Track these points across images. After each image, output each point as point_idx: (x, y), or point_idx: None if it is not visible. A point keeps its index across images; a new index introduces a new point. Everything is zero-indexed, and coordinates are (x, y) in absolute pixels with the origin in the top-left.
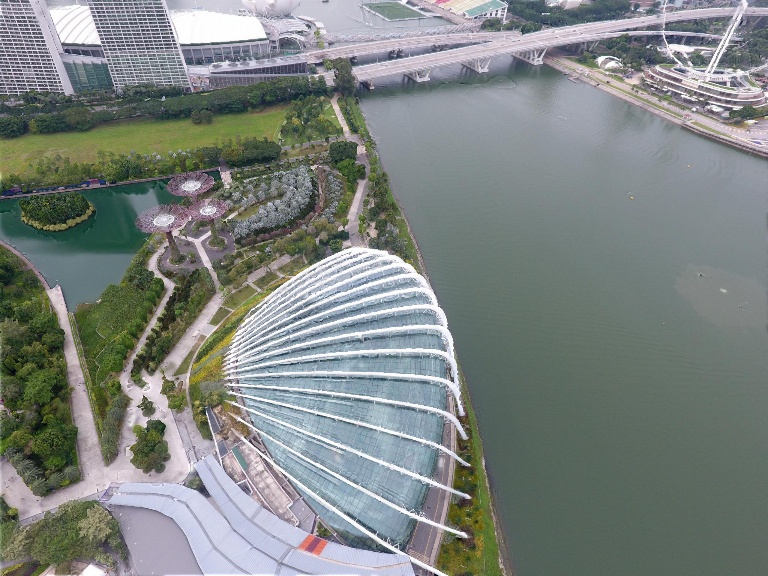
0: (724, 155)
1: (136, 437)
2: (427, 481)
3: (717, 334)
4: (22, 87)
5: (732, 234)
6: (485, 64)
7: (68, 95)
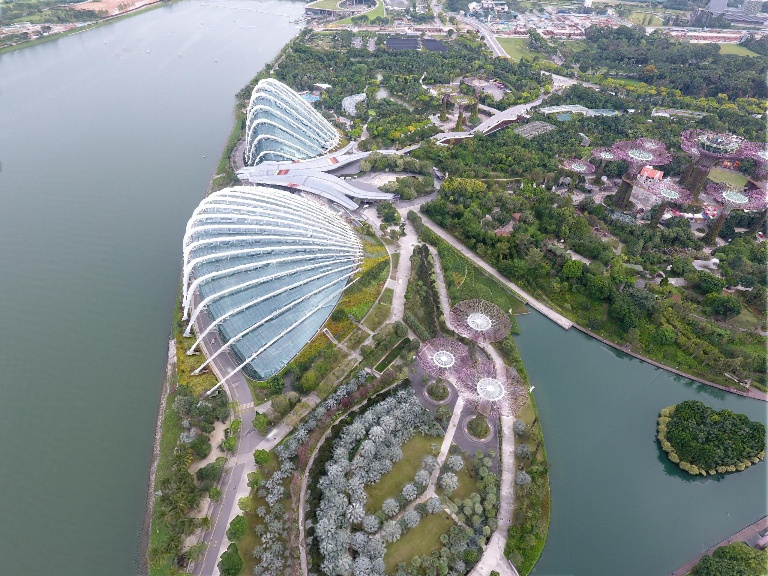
0: None
1: None
2: None
3: None
4: None
5: None
6: None
7: None
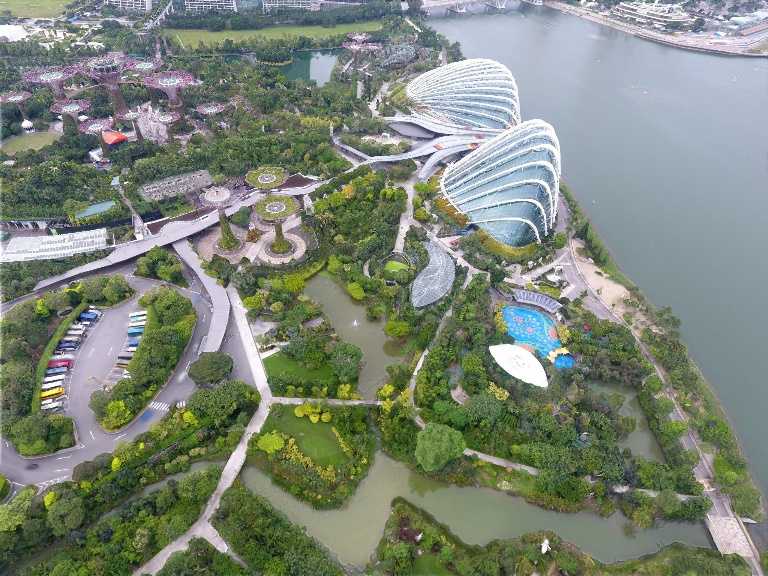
0: (660, 51)
1: None
2: (510, 111)
3: (639, 104)
4: (206, 6)
5: (655, 76)
6: (503, 3)
7: (237, 11)
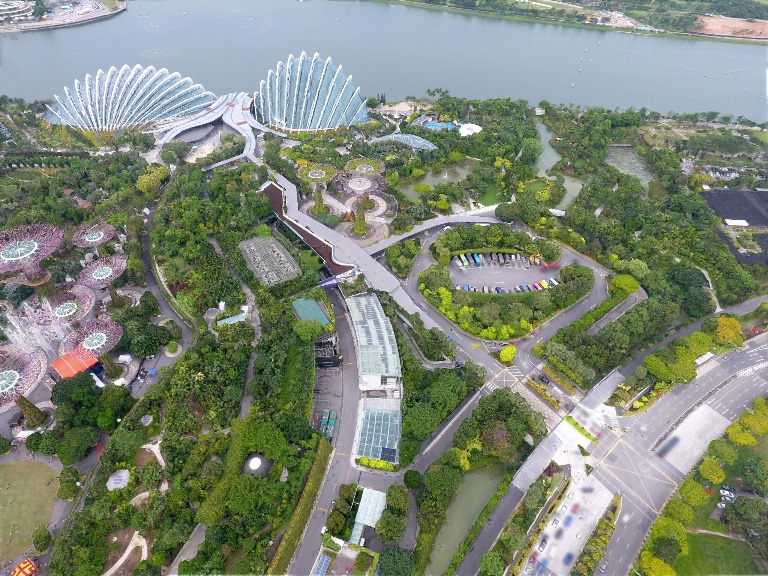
0: None
1: None
2: None
3: None
4: None
5: (125, 44)
6: None
7: None
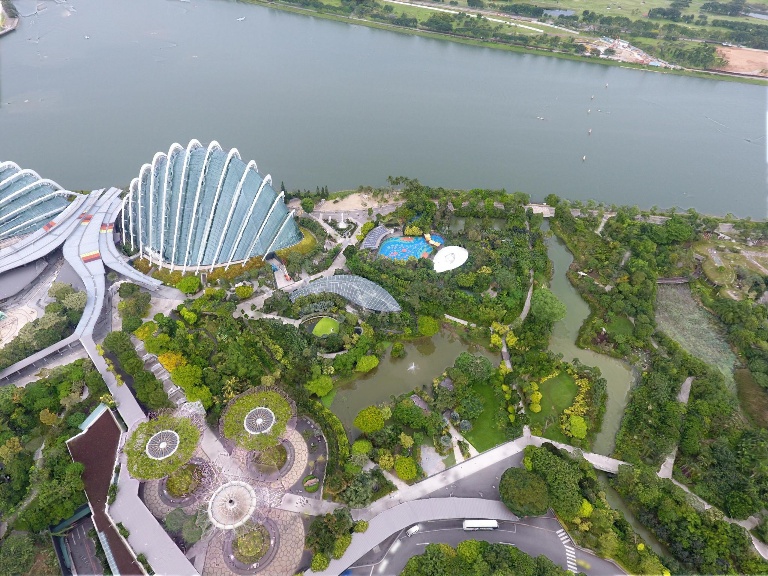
0: None
1: None
2: (45, 181)
3: (50, 112)
4: None
5: None
6: None
7: None
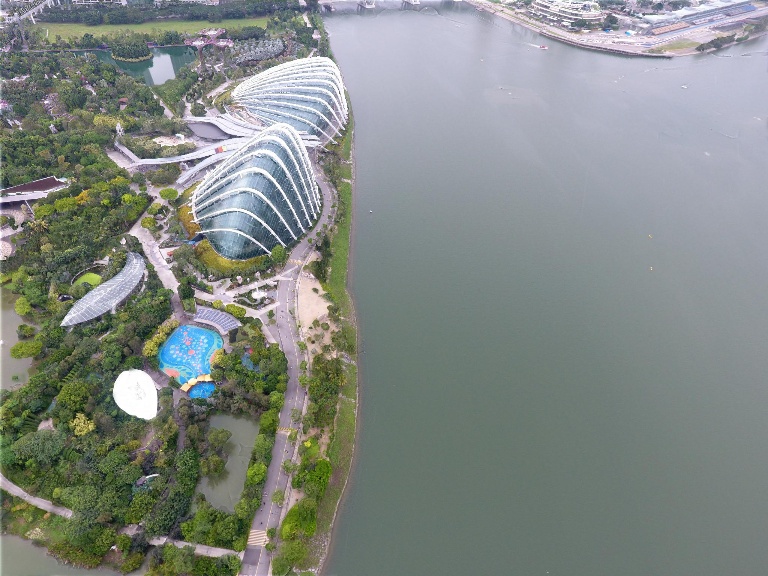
0: (563, 50)
1: (191, 114)
2: (318, 112)
3: (494, 106)
4: None
5: (533, 76)
6: None
7: (124, 5)
